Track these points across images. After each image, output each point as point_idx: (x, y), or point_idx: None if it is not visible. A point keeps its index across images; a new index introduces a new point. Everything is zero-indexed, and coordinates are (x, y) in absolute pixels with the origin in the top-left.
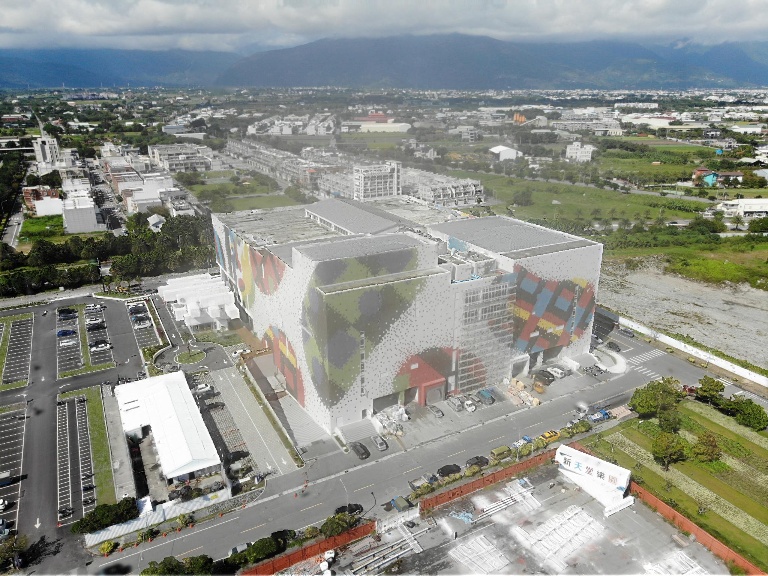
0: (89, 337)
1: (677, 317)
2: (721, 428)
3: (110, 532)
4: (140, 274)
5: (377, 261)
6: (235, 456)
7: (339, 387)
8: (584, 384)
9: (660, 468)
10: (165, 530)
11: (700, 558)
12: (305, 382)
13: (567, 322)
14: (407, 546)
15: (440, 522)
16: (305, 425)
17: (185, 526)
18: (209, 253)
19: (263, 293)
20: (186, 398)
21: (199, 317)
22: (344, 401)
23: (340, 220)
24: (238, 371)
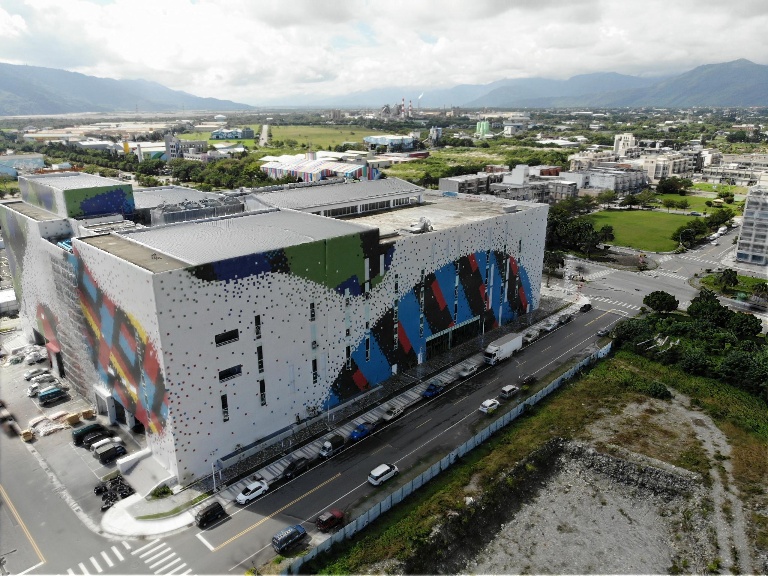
0: None
1: None
2: None
3: None
4: None
5: (39, 192)
6: None
7: None
8: (72, 480)
9: None
10: None
11: None
12: None
13: None
14: None
15: None
16: None
17: None
18: None
19: None
20: None
21: None
22: None
23: None
24: None
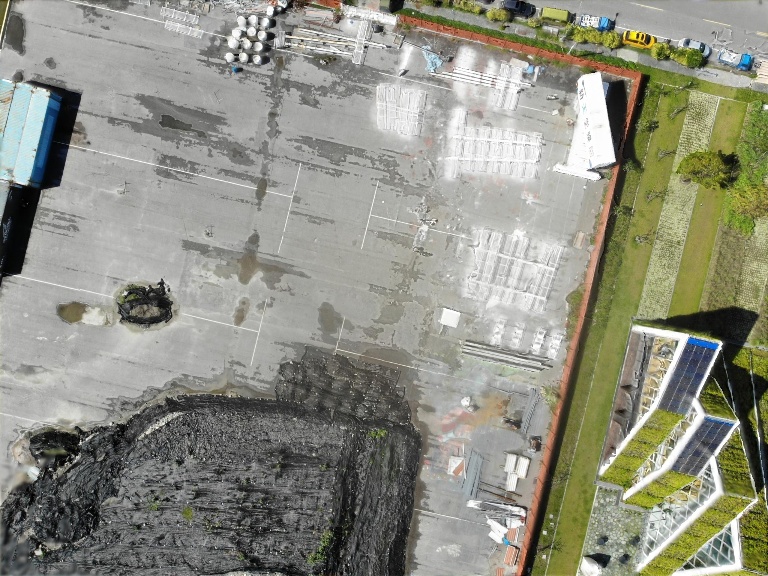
0: None
1: None
2: None
3: None
4: None
5: None
6: None
7: None
8: None
9: None
10: None
11: (570, 264)
12: None
13: None
14: (354, 48)
15: (406, 47)
16: None
17: None
18: None
19: None
20: None
21: None
22: None
23: None
24: None
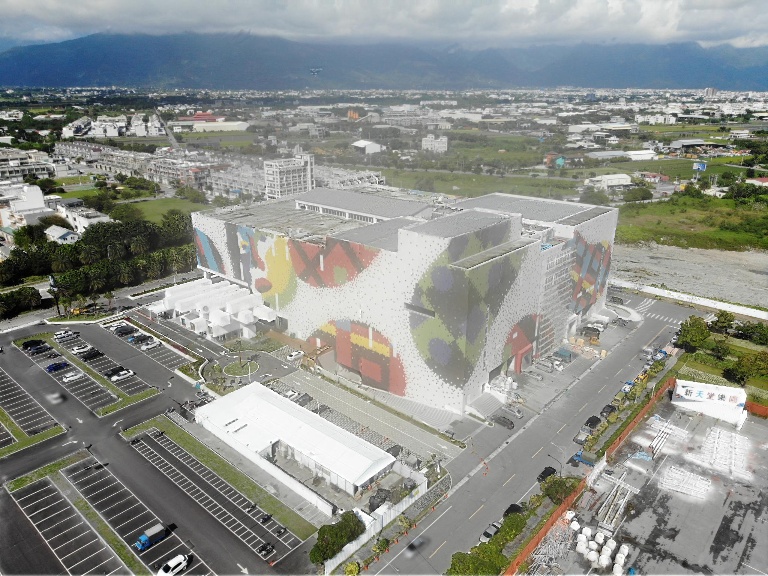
0: (92, 367)
1: (629, 273)
2: (747, 349)
3: (344, 553)
4: (88, 292)
5: (487, 235)
6: (395, 451)
7: (470, 364)
8: (623, 334)
9: (739, 386)
10: (392, 537)
11: None
12: (410, 369)
13: (596, 281)
14: (623, 491)
15: (628, 465)
16: (424, 411)
17: (409, 528)
18: (164, 261)
19: (318, 287)
20: (294, 406)
21: (226, 325)
22: (472, 377)
23: (357, 207)
24: (310, 373)
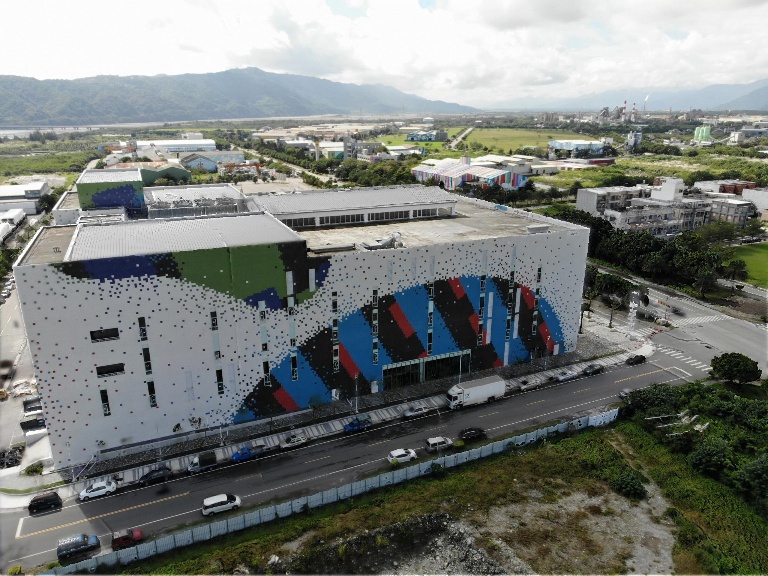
0: None
1: None
2: None
3: None
4: None
5: None
6: None
7: None
8: None
9: None
10: None
11: None
12: None
13: None
14: None
15: None
16: None
17: None
18: None
19: None
20: None
21: None
22: None
23: None
24: None
